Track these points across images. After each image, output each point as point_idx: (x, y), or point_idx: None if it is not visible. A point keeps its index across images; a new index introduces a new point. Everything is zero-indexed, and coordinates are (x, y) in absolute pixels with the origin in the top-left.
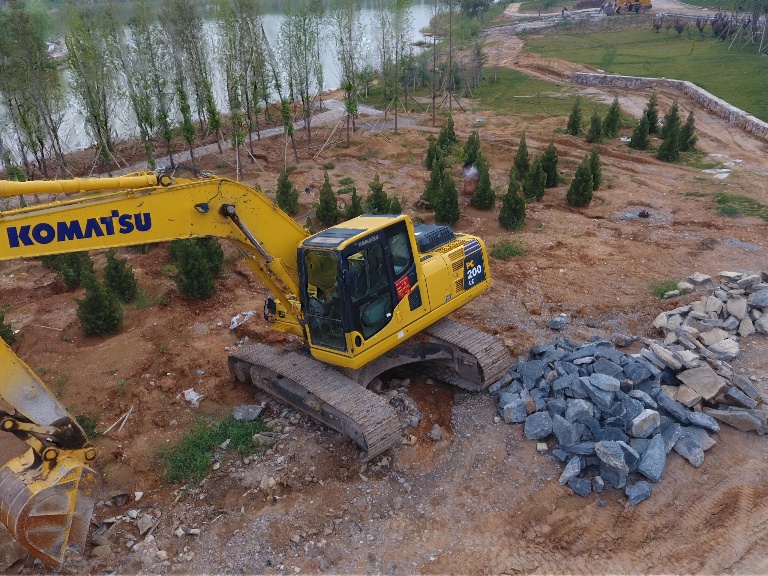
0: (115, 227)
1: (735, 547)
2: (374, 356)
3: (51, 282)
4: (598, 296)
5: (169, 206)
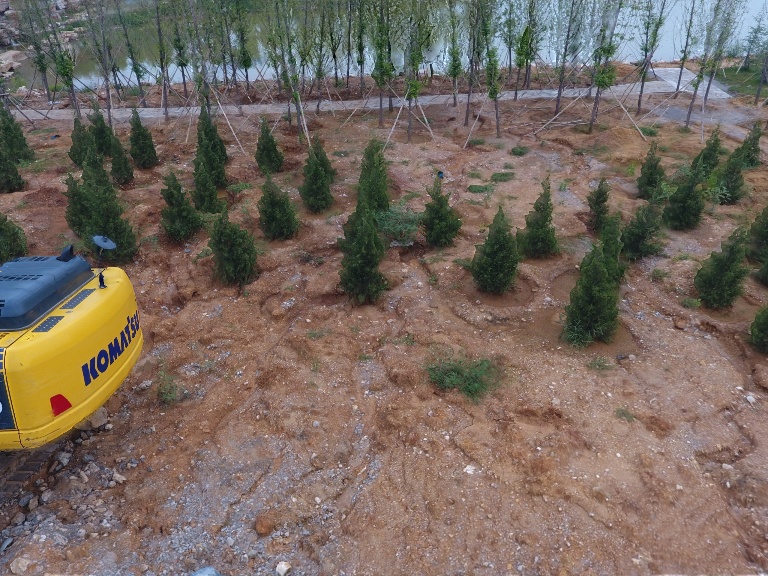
0: None
1: None
2: None
3: None
4: (403, 574)
5: None
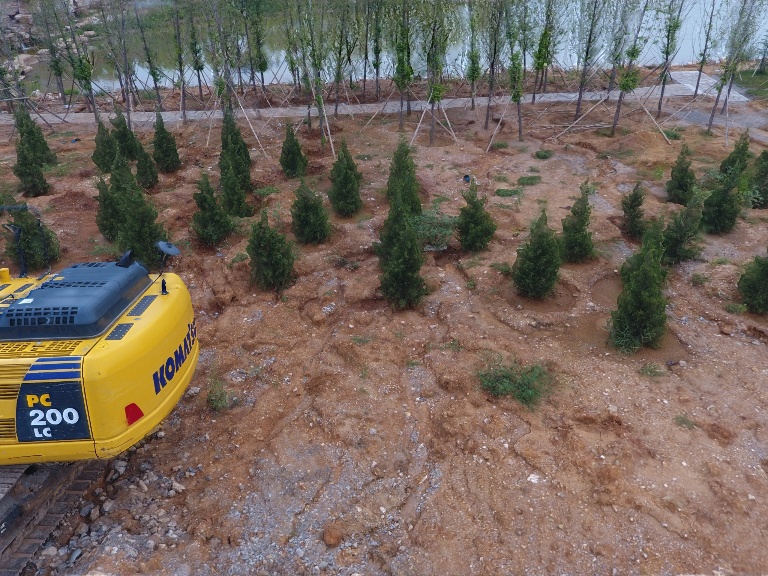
0: None
1: None
2: None
3: None
4: None
5: None
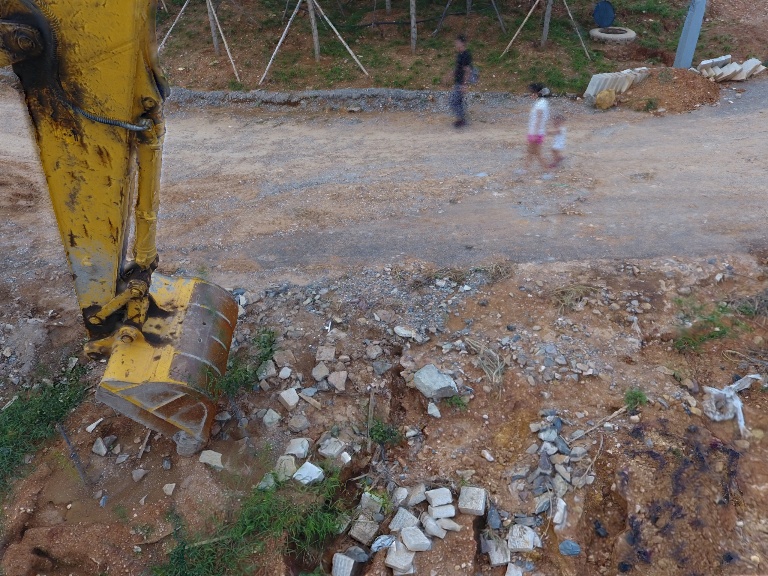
0: None
1: (7, 157)
2: None
3: None
4: None
5: None
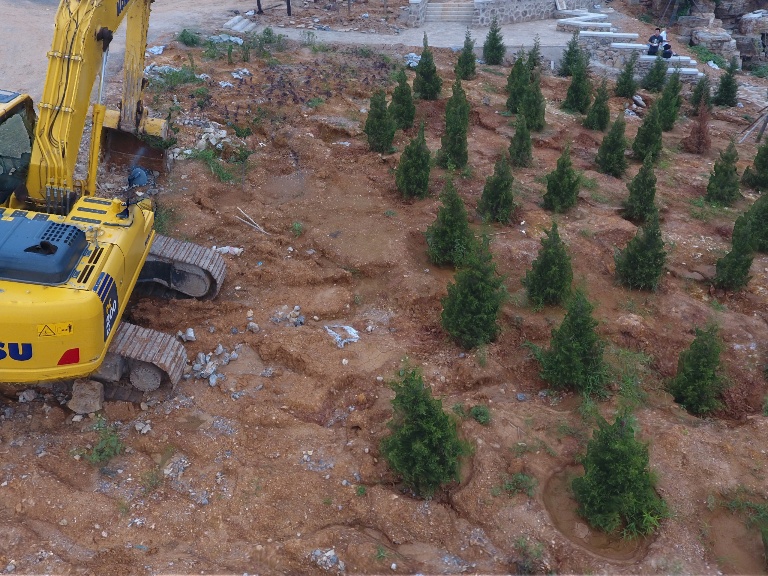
0: None
1: None
2: None
3: None
4: None
5: None
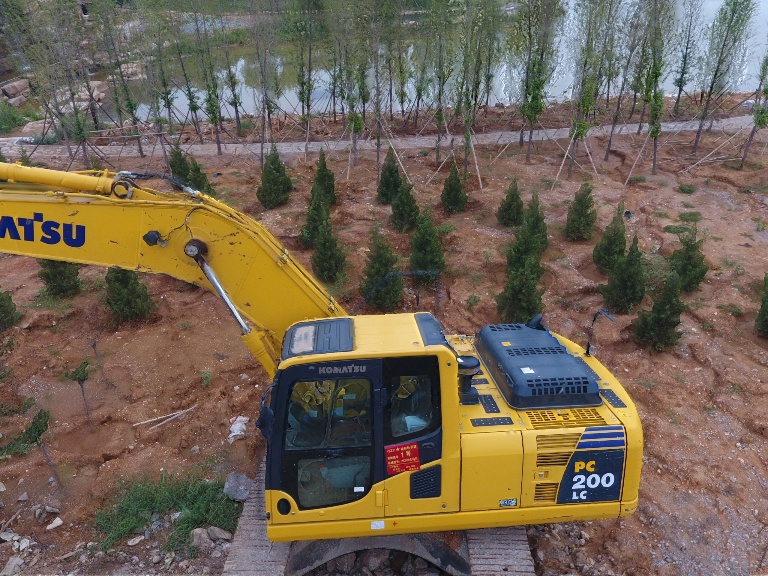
0: (36, 233)
1: None
2: (314, 536)
3: (298, 235)
4: None
5: (115, 224)
